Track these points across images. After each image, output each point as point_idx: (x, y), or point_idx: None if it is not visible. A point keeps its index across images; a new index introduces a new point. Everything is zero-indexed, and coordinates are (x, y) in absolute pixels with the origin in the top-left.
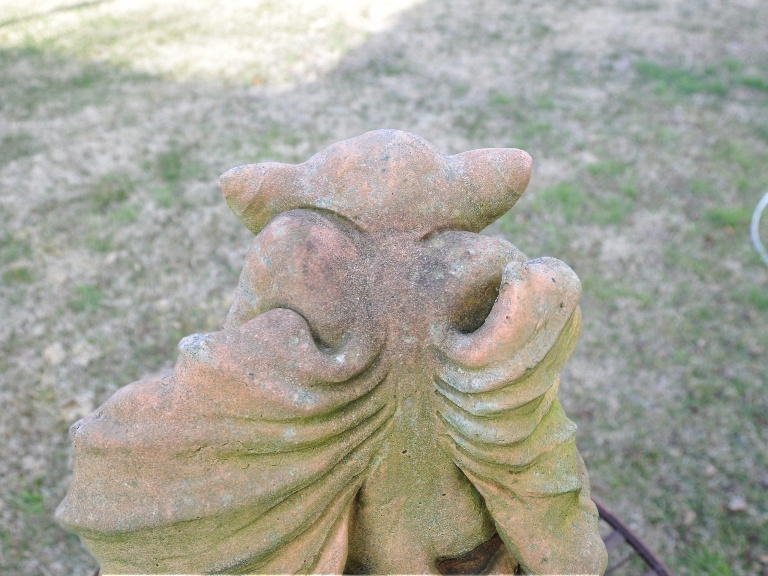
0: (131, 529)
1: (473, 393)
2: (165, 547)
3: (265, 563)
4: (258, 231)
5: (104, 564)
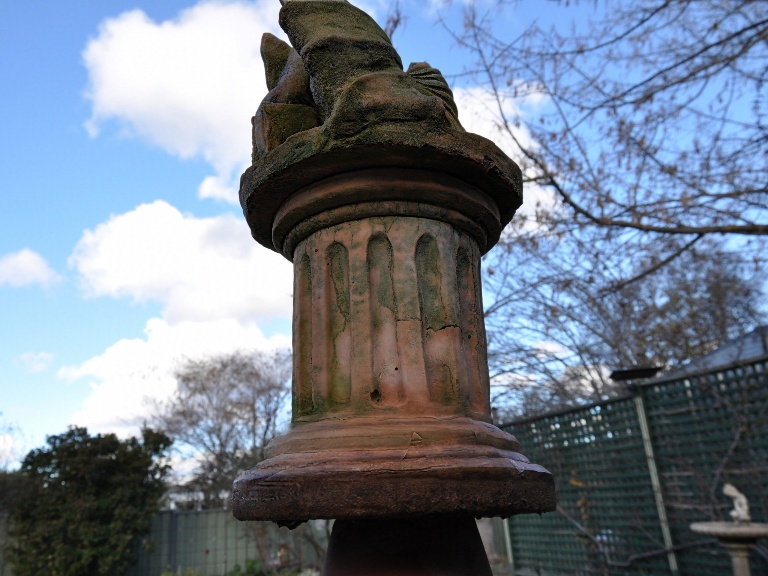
0: (342, 2)
1: (428, 72)
2: (356, 22)
3: (393, 65)
4: (282, 60)
5: (318, 29)
